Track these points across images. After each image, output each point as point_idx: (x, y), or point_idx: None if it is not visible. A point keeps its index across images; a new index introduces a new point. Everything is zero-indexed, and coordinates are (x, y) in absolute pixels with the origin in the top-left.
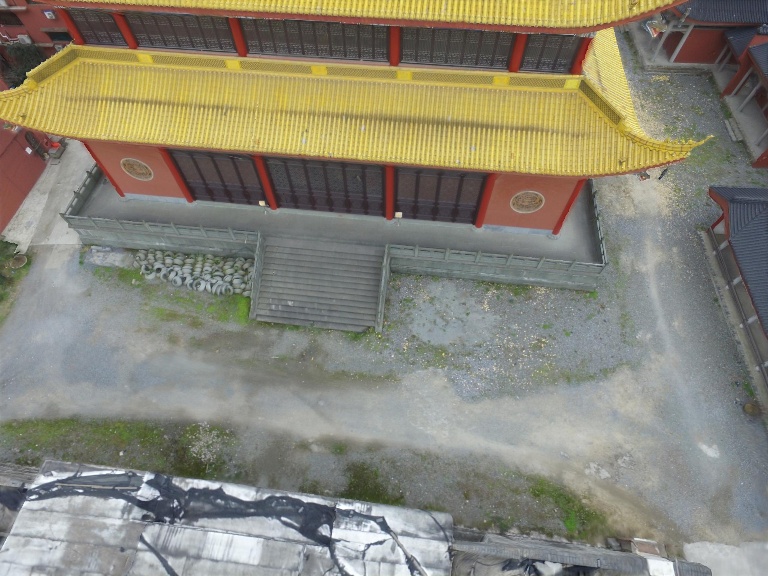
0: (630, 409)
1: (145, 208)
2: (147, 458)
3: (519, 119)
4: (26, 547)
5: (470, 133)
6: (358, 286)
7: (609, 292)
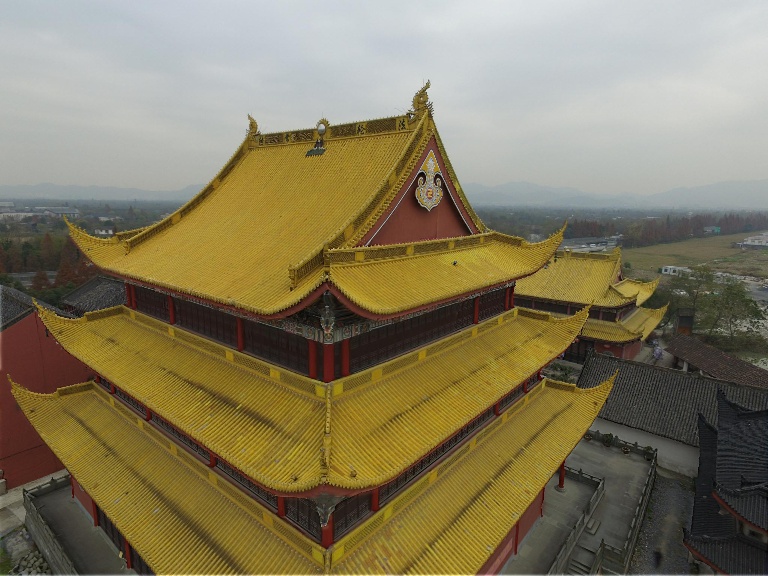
0: None
1: (72, 514)
2: None
3: (260, 571)
4: None
5: (214, 562)
6: None
7: None
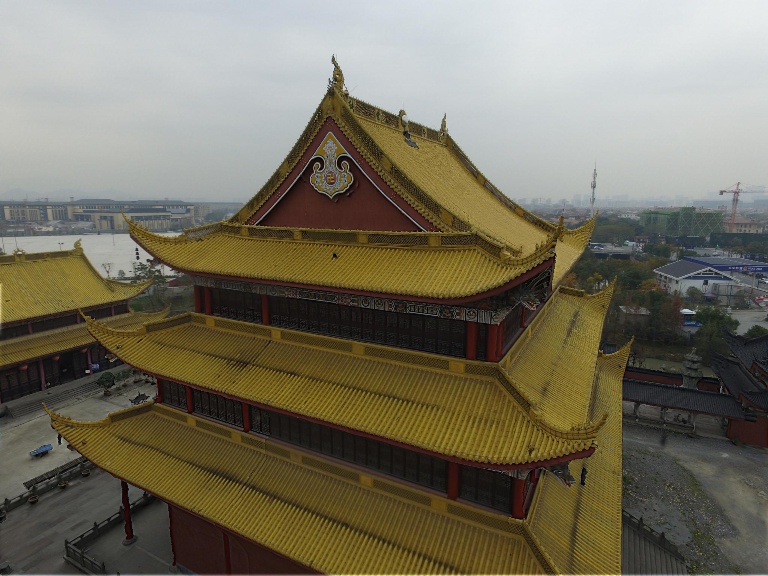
0: (709, 470)
1: None
2: None
3: None
4: None
5: None
6: (652, 554)
7: None
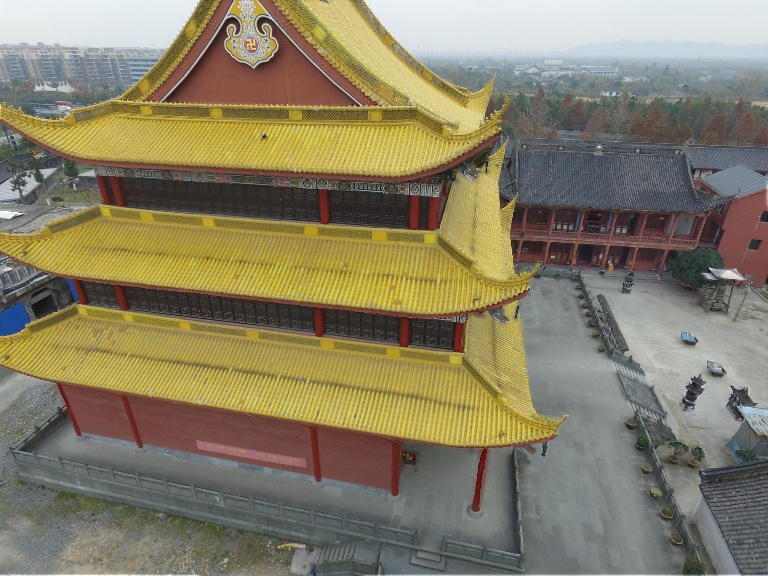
0: None
1: None
2: None
3: None
4: None
5: None
6: None
7: (8, 495)
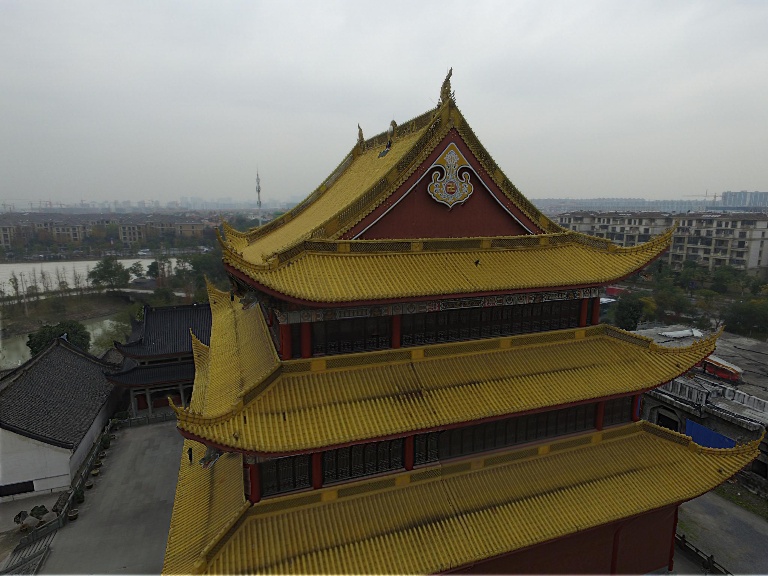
0: None
1: None
2: (722, 484)
3: None
4: (764, 416)
5: None
6: None
7: None
